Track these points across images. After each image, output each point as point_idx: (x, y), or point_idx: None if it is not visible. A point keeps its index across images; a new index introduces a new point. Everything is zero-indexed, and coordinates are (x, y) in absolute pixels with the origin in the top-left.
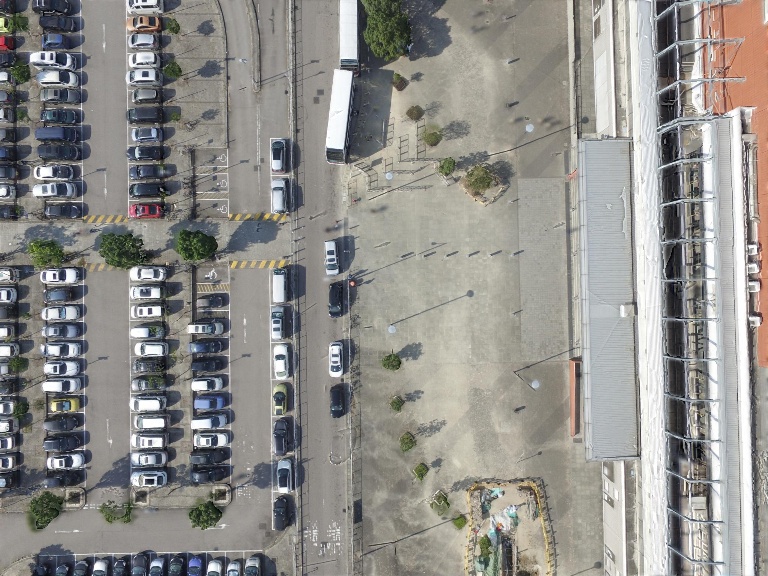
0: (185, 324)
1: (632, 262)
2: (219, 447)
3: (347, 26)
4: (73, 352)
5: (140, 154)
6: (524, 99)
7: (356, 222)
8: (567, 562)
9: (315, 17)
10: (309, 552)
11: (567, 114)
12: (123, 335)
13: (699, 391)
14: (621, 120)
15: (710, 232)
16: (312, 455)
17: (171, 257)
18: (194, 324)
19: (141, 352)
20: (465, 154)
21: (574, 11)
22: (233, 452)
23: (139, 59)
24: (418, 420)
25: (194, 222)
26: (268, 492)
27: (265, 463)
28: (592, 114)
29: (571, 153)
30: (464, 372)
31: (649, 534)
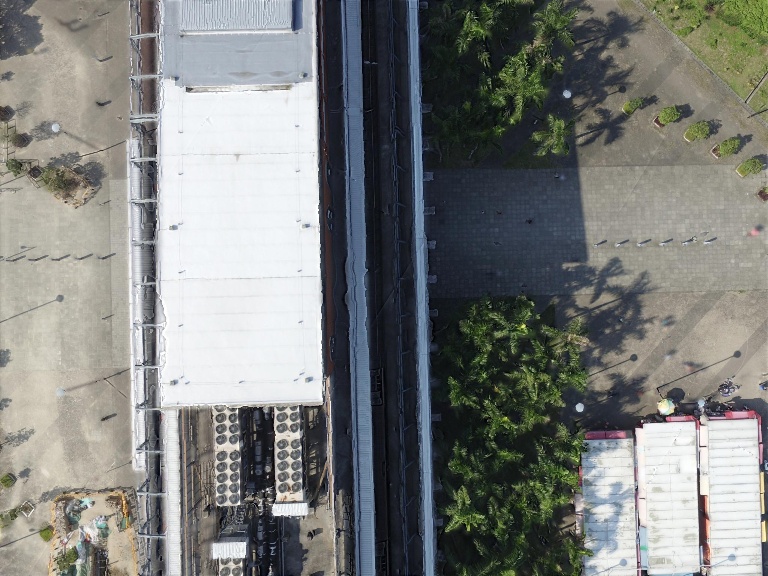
0: None
1: None
2: None
3: None
4: None
5: None
6: (117, 98)
7: None
8: None
9: None
10: None
11: None
12: None
13: None
14: None
15: None
16: None
17: None
18: None
19: None
20: (56, 155)
21: None
22: None
23: None
24: (6, 429)
25: None
26: None
27: None
28: None
29: None
30: (53, 379)
31: None
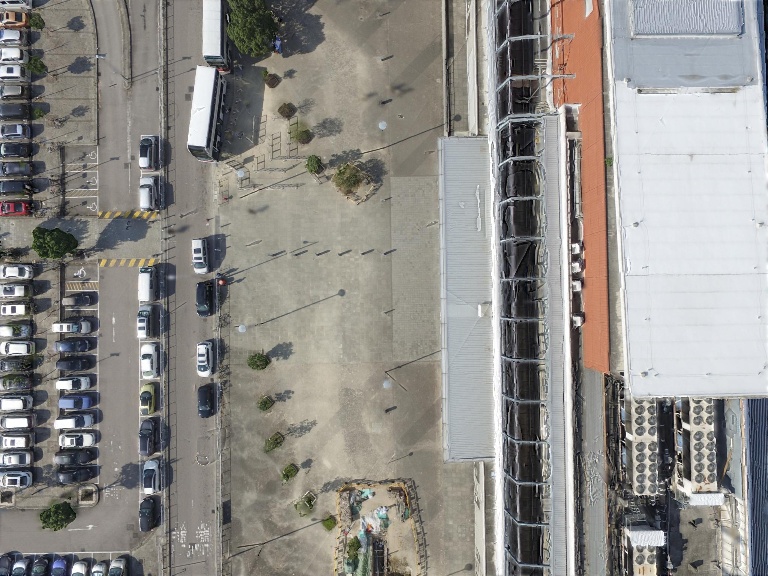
0: (52, 323)
1: None
2: (86, 447)
3: (210, 22)
4: None
5: (5, 151)
6: (398, 97)
7: (227, 220)
8: (438, 564)
9: (187, 13)
10: (177, 553)
11: (441, 112)
12: None
13: None
14: (483, 118)
15: None
16: (181, 455)
17: None
18: (59, 323)
19: (5, 351)
20: (338, 152)
21: (447, 8)
22: (101, 452)
23: (5, 55)
24: (288, 420)
25: (63, 220)
26: (136, 493)
27: (133, 463)
28: (465, 112)
29: None
30: (335, 372)
31: (497, 536)
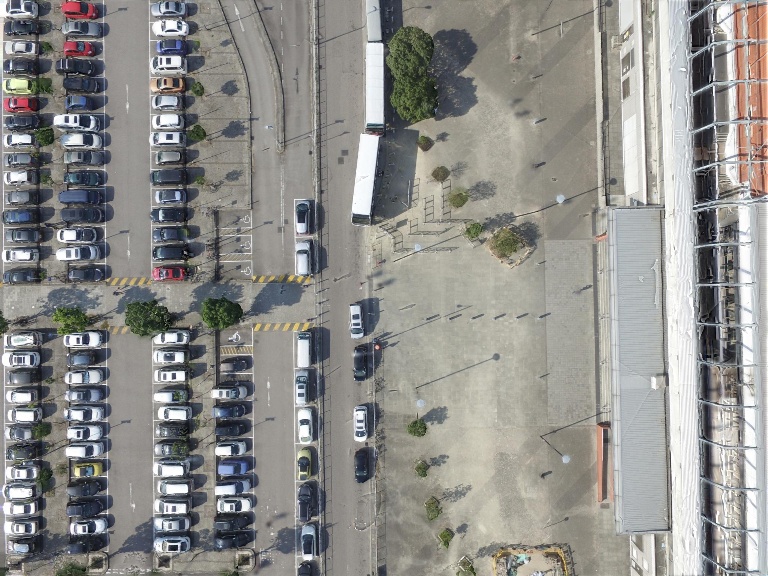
0: (208, 387)
1: (663, 331)
2: (242, 512)
3: (373, 90)
4: (96, 416)
5: (164, 217)
6: (551, 160)
7: (381, 284)
8: None
9: (340, 77)
10: None
11: (595, 175)
12: (146, 398)
13: (733, 469)
14: (652, 187)
15: (747, 312)
16: (336, 520)
17: (194, 320)
18: (218, 389)
19: (165, 417)
20: (491, 215)
21: (602, 71)
22: (257, 517)
23: (163, 121)
24: (443, 485)
25: (218, 284)
26: (292, 557)
27: (289, 528)
28: (620, 175)
29: (599, 215)
30: (490, 436)
31: None
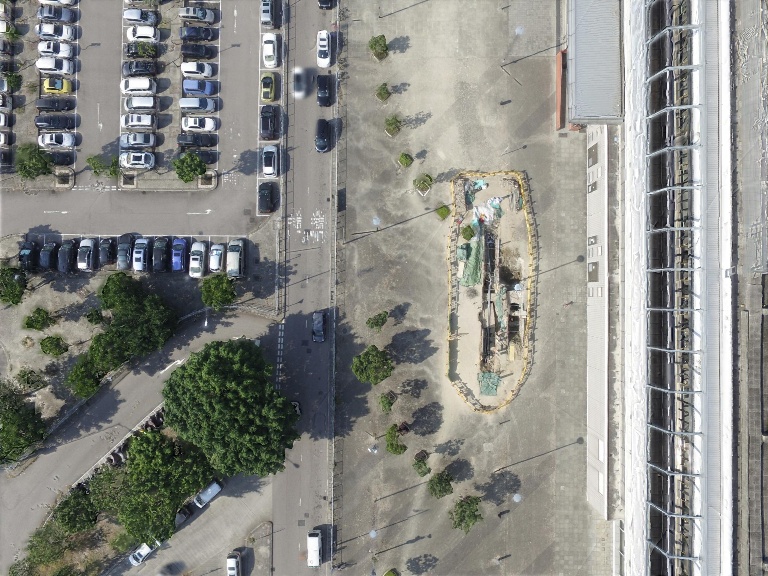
0: (177, 12)
1: None
2: (207, 133)
3: None
4: (67, 32)
5: None
6: None
7: None
8: (550, 255)
9: None
10: (292, 239)
11: None
12: (116, 23)
13: (682, 29)
14: None
15: None
16: (298, 144)
17: None
18: (185, 7)
19: (133, 33)
20: None
21: None
22: (220, 139)
23: None
24: (404, 112)
25: None
26: (253, 179)
27: (251, 150)
28: None
29: None
30: (451, 66)
31: (629, 170)
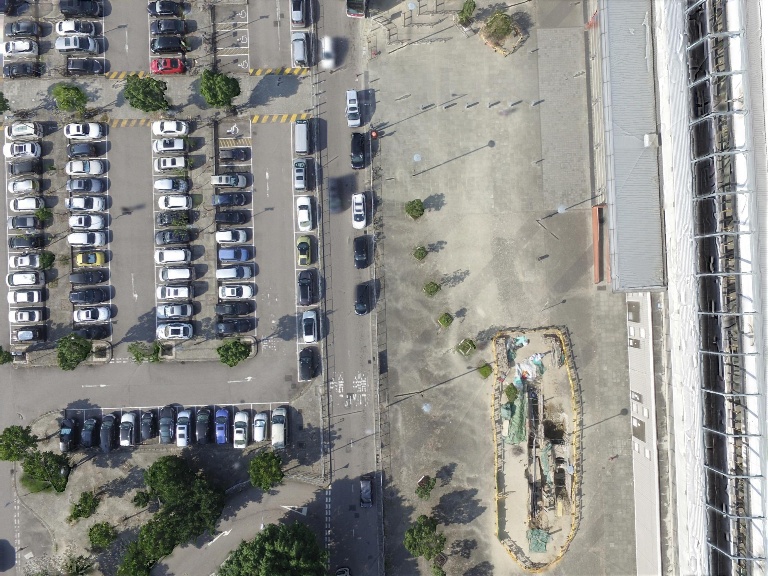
0: (208, 178)
1: (655, 96)
2: (244, 300)
3: None
4: (97, 205)
5: (161, 8)
6: None
7: (376, 75)
8: (593, 409)
9: None
10: (335, 403)
11: None
12: (146, 190)
13: (726, 208)
14: None
15: (735, 38)
16: (336, 307)
17: (193, 112)
18: (217, 175)
19: (165, 204)
20: (484, 6)
21: None
22: (258, 305)
23: None
24: (442, 270)
25: None
26: (293, 344)
27: (290, 315)
28: None
29: (590, 2)
30: (487, 222)
31: (679, 352)
